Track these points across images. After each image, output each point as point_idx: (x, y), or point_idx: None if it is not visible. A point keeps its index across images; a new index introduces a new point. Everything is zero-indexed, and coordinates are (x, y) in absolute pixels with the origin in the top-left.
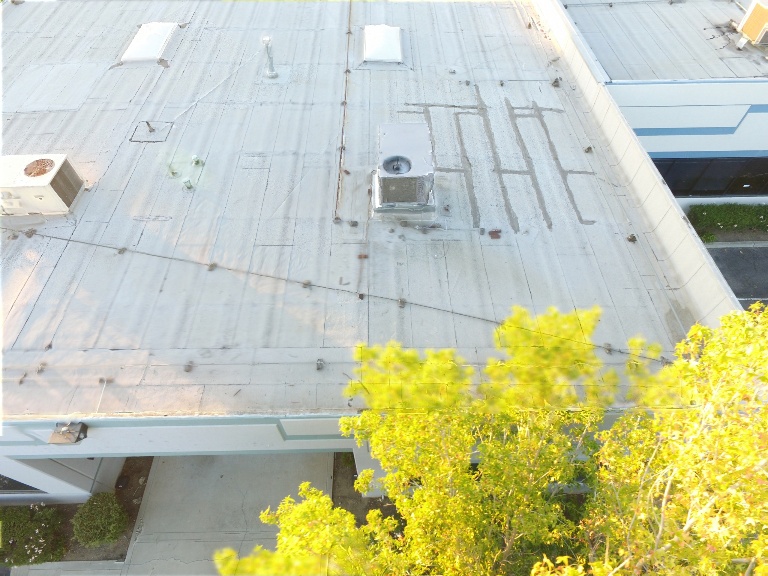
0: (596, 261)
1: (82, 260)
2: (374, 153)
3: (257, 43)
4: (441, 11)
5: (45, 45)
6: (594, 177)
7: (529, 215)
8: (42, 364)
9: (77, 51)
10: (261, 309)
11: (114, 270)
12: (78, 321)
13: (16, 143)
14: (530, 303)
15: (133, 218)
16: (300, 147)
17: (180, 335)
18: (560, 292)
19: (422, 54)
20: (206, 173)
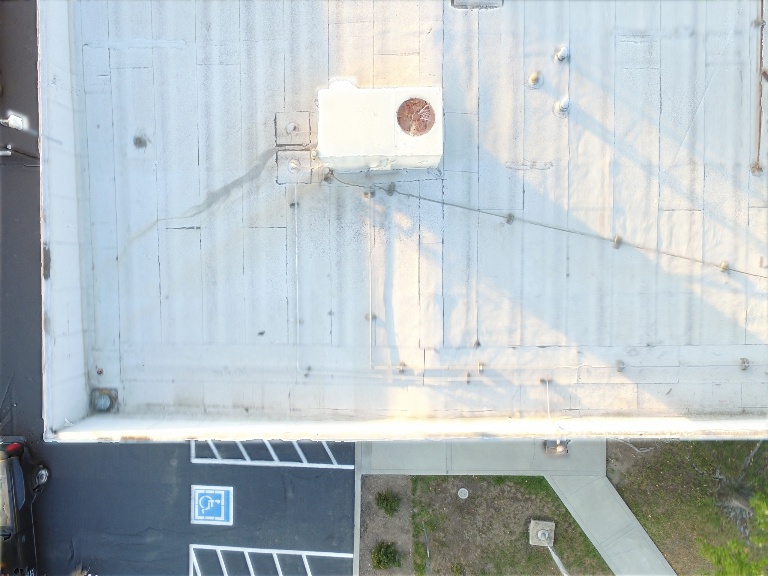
0: None
1: (469, 233)
2: None
3: None
4: None
5: None
6: None
7: None
8: (481, 364)
9: None
10: (679, 300)
11: (509, 247)
12: (495, 315)
13: (281, 4)
14: None
15: (506, 165)
16: (698, 20)
17: (602, 331)
18: None
19: None
20: (577, 79)
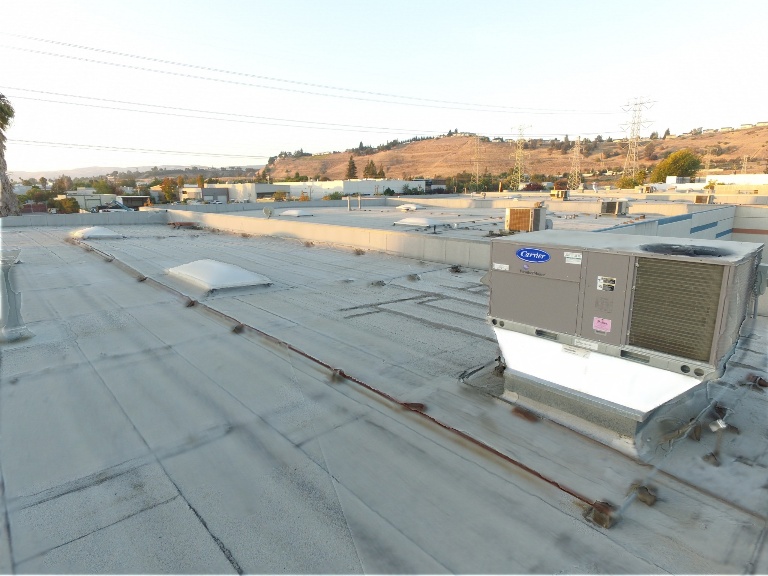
0: None
1: None
2: (404, 363)
3: None
4: (254, 257)
5: None
6: None
7: None
8: None
9: None
10: None
11: None
12: None
13: None
14: None
15: None
16: (228, 409)
17: None
18: None
19: (284, 278)
20: None
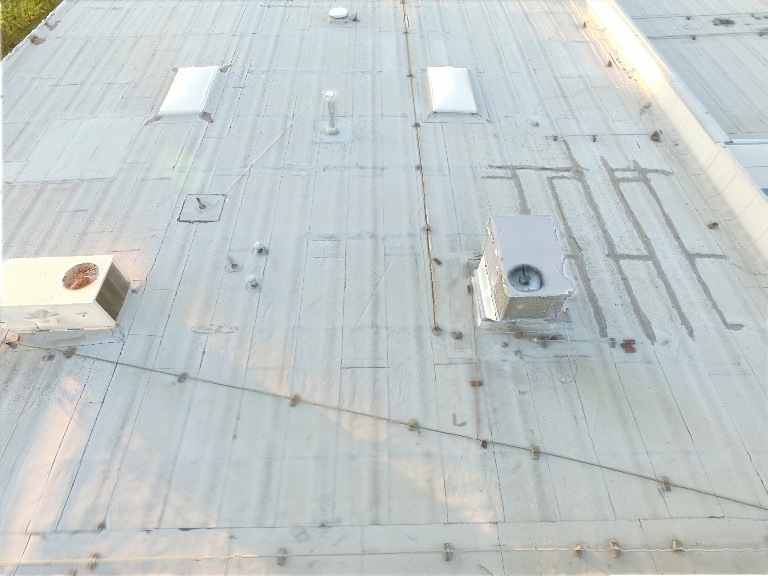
0: (758, 384)
1: (135, 392)
2: (465, 234)
3: (309, 90)
4: (507, 47)
5: (71, 94)
6: (727, 262)
7: (663, 318)
8: (96, 555)
9: (107, 101)
10: (362, 464)
11: (175, 406)
12: (136, 485)
13: (45, 223)
14: (692, 449)
15: (191, 329)
16: (377, 227)
17: (266, 506)
18: (725, 431)
19: (496, 101)
20: (271, 264)
